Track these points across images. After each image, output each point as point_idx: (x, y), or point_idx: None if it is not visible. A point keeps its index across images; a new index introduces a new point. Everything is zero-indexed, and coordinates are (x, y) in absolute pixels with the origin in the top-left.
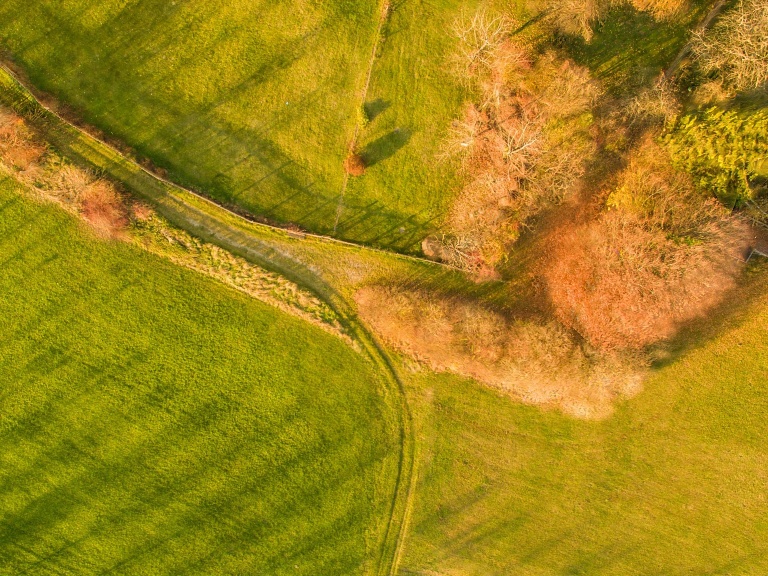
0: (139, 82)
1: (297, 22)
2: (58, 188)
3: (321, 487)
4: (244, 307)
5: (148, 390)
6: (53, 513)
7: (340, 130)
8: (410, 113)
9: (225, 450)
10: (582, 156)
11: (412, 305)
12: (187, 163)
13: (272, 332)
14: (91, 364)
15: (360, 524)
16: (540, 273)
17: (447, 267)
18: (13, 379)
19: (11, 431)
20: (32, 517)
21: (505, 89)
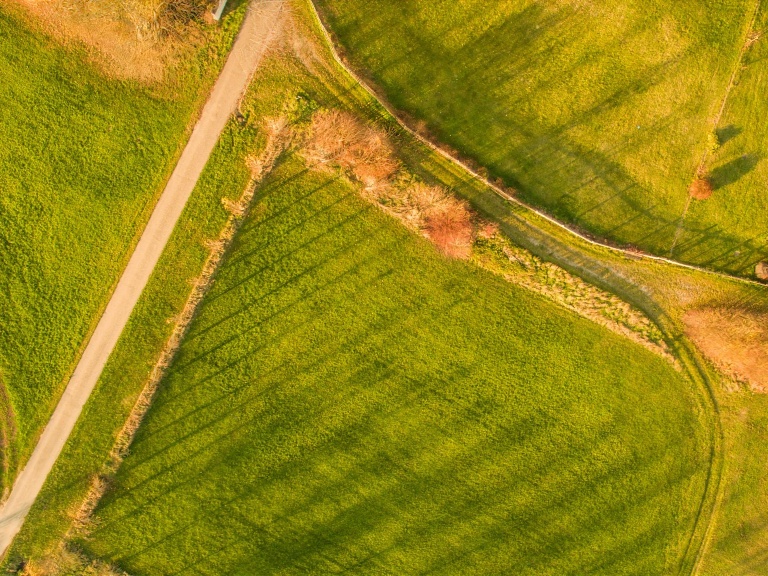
0: (495, 103)
1: (660, 49)
2: (402, 205)
3: (628, 503)
4: (571, 325)
5: (467, 405)
6: (361, 524)
7: (688, 155)
8: (759, 140)
9: (537, 465)
10: None
11: (761, 328)
12: (535, 183)
13: (596, 350)
14: (414, 378)
15: (662, 540)
16: None
17: None
18: (334, 391)
19: (327, 442)
20: (340, 527)
21: None
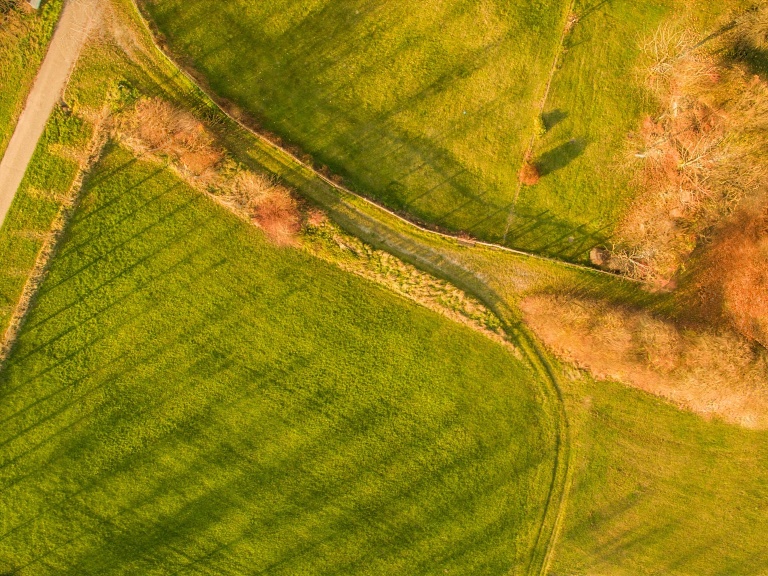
0: (318, 90)
1: (481, 33)
2: (231, 193)
3: (475, 492)
4: (409, 313)
5: (308, 395)
6: (207, 516)
7: (515, 140)
8: (586, 124)
9: (382, 455)
10: (766, 169)
11: (588, 314)
12: (362, 170)
13: (435, 338)
14: (253, 368)
15: (512, 529)
16: (707, 283)
17: (615, 276)
18: (174, 382)
19: (169, 434)
20: (186, 519)
21: (683, 102)
